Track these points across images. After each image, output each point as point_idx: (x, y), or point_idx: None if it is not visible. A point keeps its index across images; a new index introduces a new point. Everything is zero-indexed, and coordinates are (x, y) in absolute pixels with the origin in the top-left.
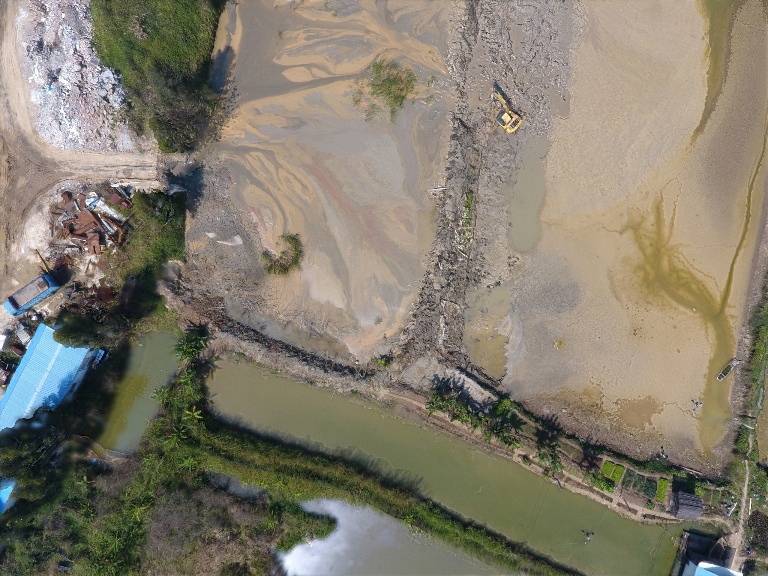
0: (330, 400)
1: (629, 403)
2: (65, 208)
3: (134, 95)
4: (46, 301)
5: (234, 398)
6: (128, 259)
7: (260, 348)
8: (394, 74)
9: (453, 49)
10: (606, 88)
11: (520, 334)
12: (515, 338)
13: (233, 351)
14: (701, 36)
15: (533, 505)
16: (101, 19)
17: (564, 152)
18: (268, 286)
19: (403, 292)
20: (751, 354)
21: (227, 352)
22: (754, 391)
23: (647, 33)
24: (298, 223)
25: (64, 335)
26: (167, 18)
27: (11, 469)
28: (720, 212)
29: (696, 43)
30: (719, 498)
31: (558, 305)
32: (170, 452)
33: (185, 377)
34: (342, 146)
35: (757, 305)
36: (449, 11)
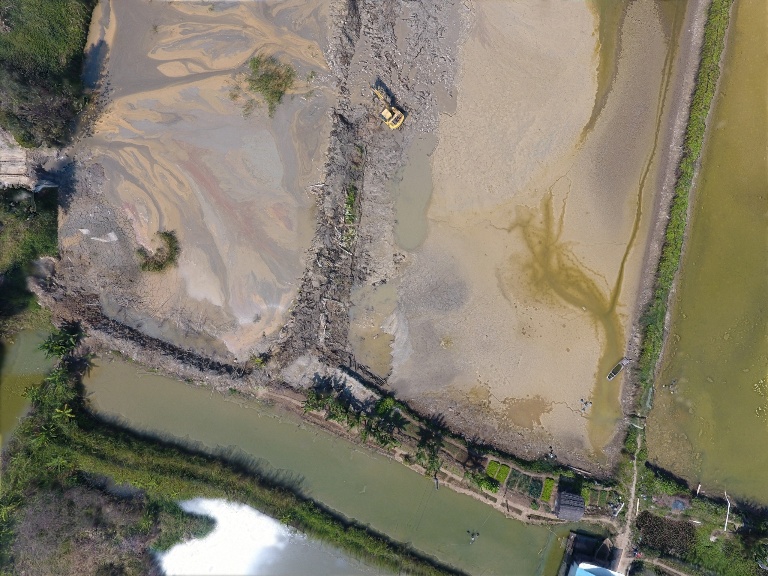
0: (209, 399)
1: (517, 402)
2: None
3: None
4: None
5: (114, 396)
6: None
7: (134, 346)
8: (272, 69)
9: (333, 44)
10: (494, 84)
11: (406, 332)
12: (401, 336)
13: (109, 349)
14: (591, 32)
15: (417, 505)
16: None
17: (451, 149)
18: (144, 283)
19: (282, 290)
20: (640, 353)
21: (103, 350)
22: (643, 390)
23: (536, 29)
24: (174, 219)
25: None
26: (32, 11)
27: None
28: (610, 210)
29: (586, 39)
30: (606, 498)
31: (445, 303)
32: (38, 451)
33: (53, 375)
34: (219, 142)
35: (647, 304)
36: (329, 6)
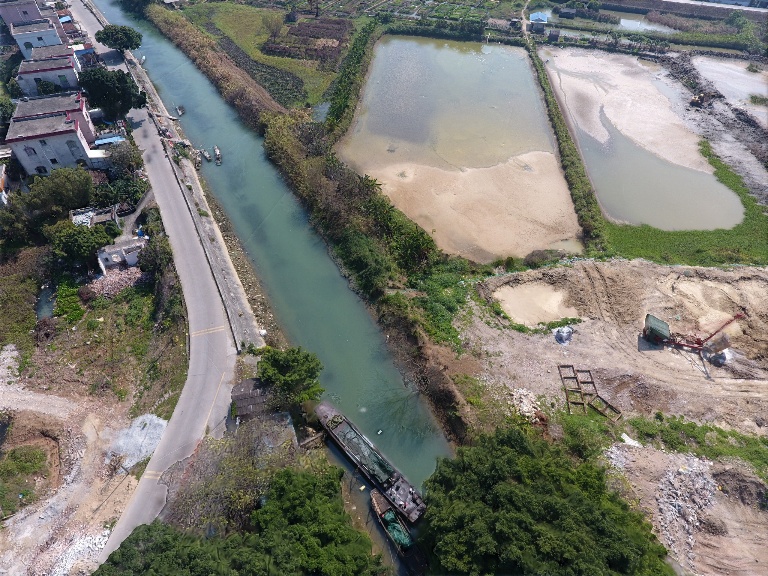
0: None
1: None
2: None
3: None
4: None
5: None
6: None
7: (740, 54)
8: None
9: None
10: (658, 114)
11: None
12: None
13: None
14: None
15: None
16: None
17: None
18: None
19: (700, 65)
20: None
21: None
22: None
23: None
24: None
25: None
26: None
27: None
28: None
29: None
30: None
31: (630, 71)
32: None
33: None
34: None
35: None
36: (759, 119)
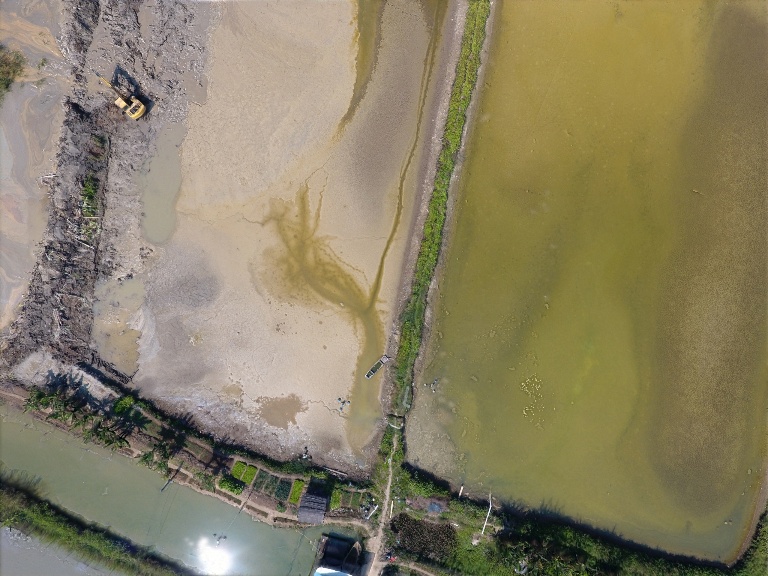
0: None
1: (271, 401)
2: None
3: None
4: None
5: None
6: None
7: None
8: (1, 56)
9: (65, 30)
10: (246, 73)
11: (153, 329)
12: (148, 333)
13: None
14: (349, 20)
15: (162, 507)
16: None
17: (201, 139)
18: None
19: (12, 284)
20: None
21: None
22: (399, 389)
23: (290, 17)
24: None
25: None
26: None
27: None
28: (369, 203)
29: (344, 28)
30: (360, 500)
31: (194, 299)
32: None
33: None
34: None
35: (407, 300)
36: None
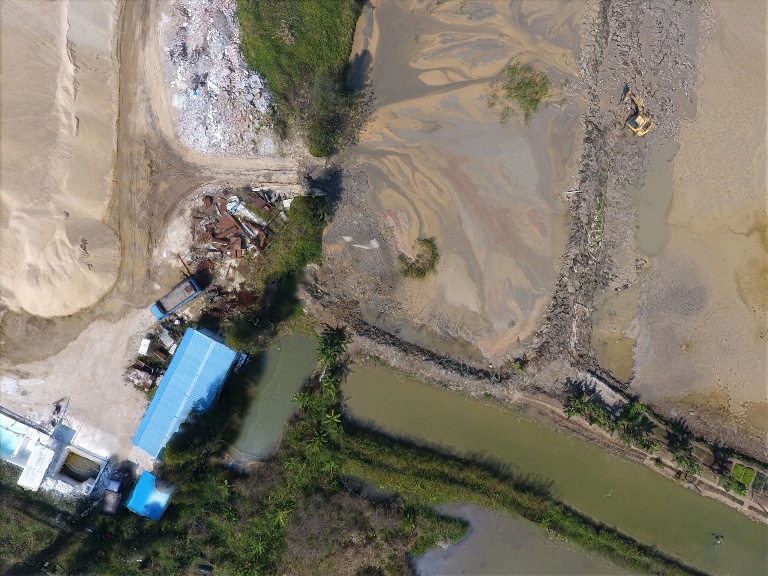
0: (462, 403)
1: (756, 406)
2: (206, 212)
3: (283, 99)
4: (187, 305)
5: (364, 401)
6: (268, 263)
7: (397, 352)
8: (528, 77)
9: (586, 52)
10: (733, 90)
11: (648, 337)
12: (643, 341)
13: (368, 355)
14: None
15: (663, 508)
16: (250, 24)
17: (691, 155)
18: (403, 290)
19: (537, 295)
20: None
21: (362, 356)
22: None
23: None
24: (434, 226)
25: (239, 340)
26: (313, 22)
27: (180, 474)
28: None
29: None
30: None
31: (685, 308)
32: (312, 456)
33: (328, 381)
34: (477, 149)
35: None
36: (582, 14)
